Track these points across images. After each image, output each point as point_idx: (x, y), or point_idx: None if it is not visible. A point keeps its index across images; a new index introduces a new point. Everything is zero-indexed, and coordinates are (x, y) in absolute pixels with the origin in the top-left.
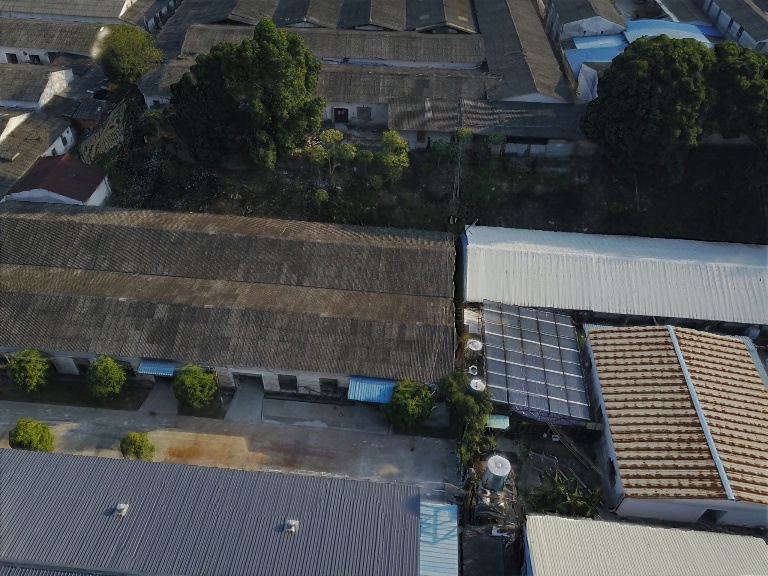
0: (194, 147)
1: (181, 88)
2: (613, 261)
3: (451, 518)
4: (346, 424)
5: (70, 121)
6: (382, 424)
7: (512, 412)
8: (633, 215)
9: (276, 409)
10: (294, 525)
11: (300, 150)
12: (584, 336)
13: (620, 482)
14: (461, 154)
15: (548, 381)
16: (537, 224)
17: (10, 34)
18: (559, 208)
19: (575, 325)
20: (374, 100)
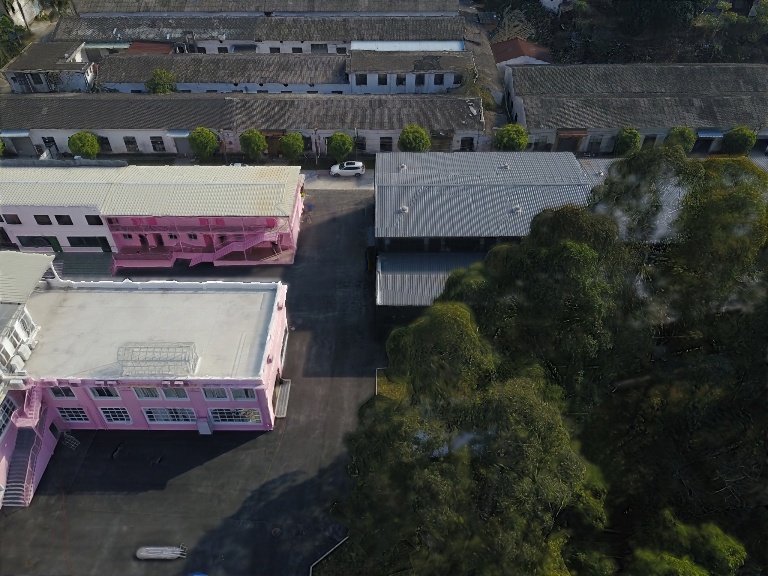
0: (640, 16)
1: None
2: None
3: None
4: None
5: None
6: None
7: None
8: None
9: None
10: None
11: None
12: None
13: None
14: None
15: None
16: None
17: None
18: None
19: None
20: None
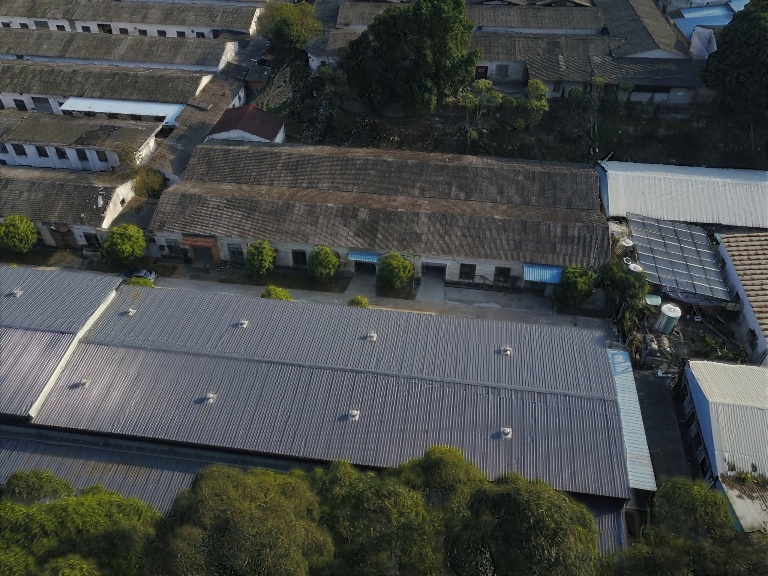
0: (369, 93)
1: (360, 43)
2: (737, 185)
3: (625, 360)
4: (517, 306)
5: (244, 82)
6: (547, 306)
7: (663, 293)
8: (748, 154)
9: (457, 294)
10: (509, 350)
11: (450, 99)
12: (716, 242)
13: (764, 341)
14: (595, 99)
15: (691, 271)
16: (660, 162)
17: (181, 15)
18: (680, 148)
19: (707, 234)
20: (512, 58)
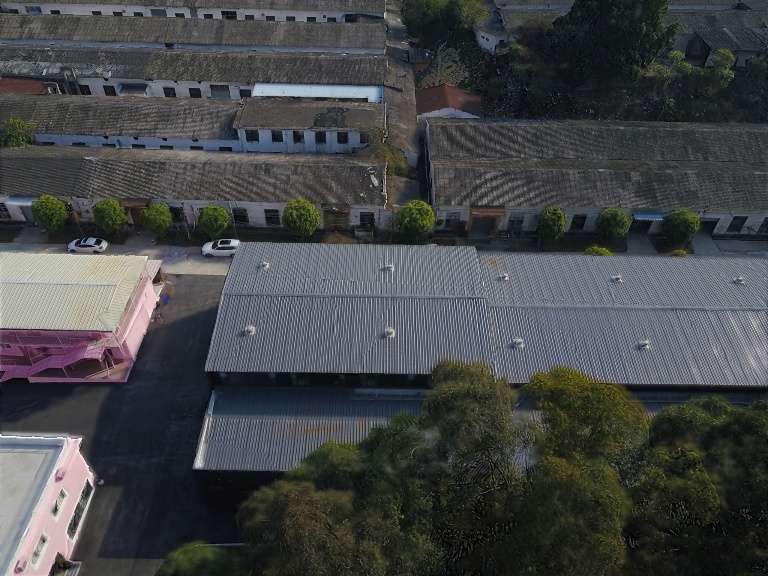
0: (580, 67)
1: (570, 19)
2: None
3: None
4: None
5: (411, 64)
6: None
7: None
8: None
9: (728, 245)
10: None
11: None
12: None
13: None
14: None
15: None
16: None
17: (310, 0)
18: None
19: None
20: (680, 32)
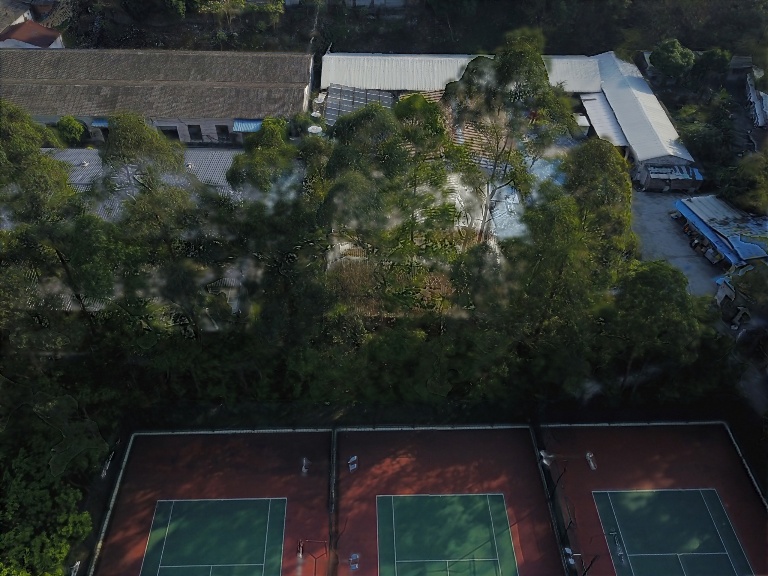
0: (124, 1)
1: None
2: (423, 61)
3: None
4: None
5: (29, 6)
6: None
7: None
8: (449, 44)
9: None
10: (190, 165)
11: (205, 9)
12: None
13: None
14: (320, 1)
15: None
16: None
17: None
18: (396, 41)
19: (393, 97)
20: None
